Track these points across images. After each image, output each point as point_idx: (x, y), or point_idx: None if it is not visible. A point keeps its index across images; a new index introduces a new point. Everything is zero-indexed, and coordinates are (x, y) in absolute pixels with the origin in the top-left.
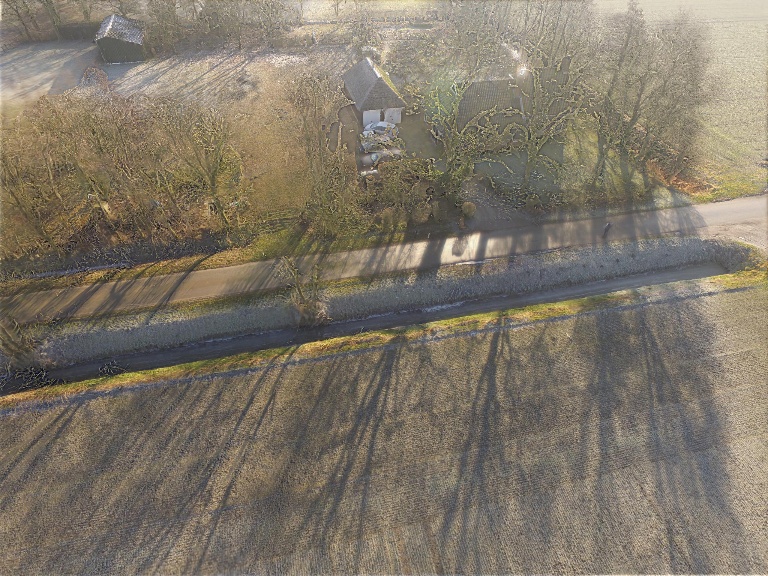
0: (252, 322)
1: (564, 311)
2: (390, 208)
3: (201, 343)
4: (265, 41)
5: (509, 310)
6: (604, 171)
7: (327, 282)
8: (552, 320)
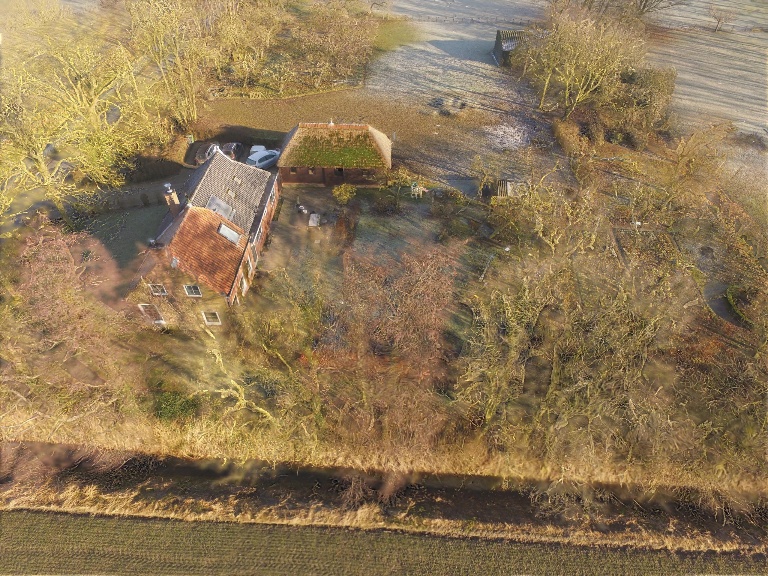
0: None
1: None
2: None
3: None
4: (579, 126)
5: None
6: None
7: None
8: None
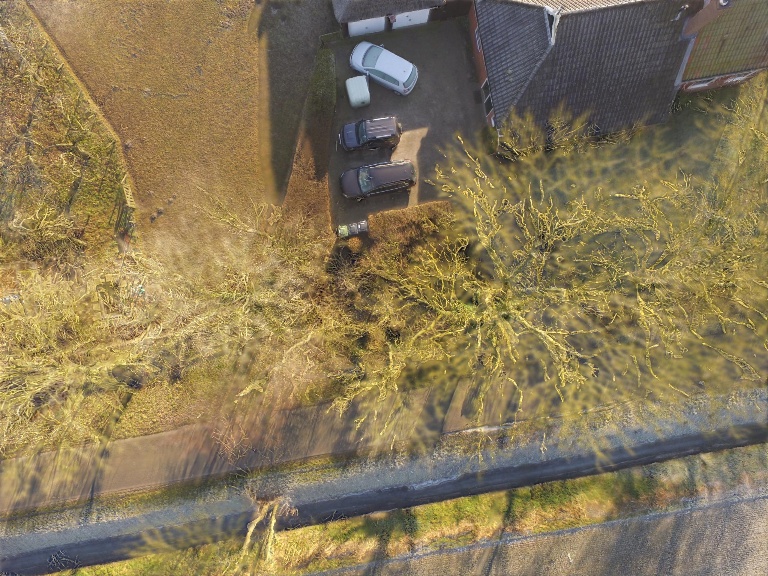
0: (203, 514)
1: (578, 521)
2: (379, 357)
3: (150, 530)
4: None
5: (514, 498)
6: (766, 209)
7: (289, 464)
8: (559, 533)
